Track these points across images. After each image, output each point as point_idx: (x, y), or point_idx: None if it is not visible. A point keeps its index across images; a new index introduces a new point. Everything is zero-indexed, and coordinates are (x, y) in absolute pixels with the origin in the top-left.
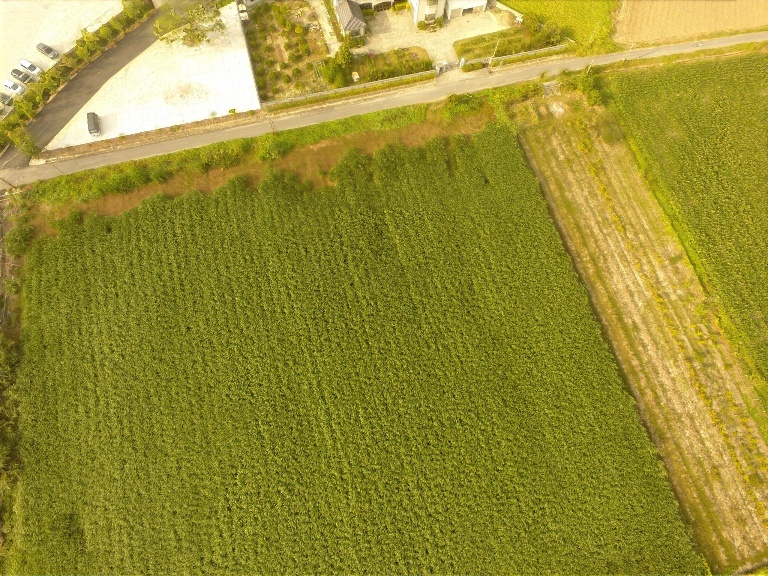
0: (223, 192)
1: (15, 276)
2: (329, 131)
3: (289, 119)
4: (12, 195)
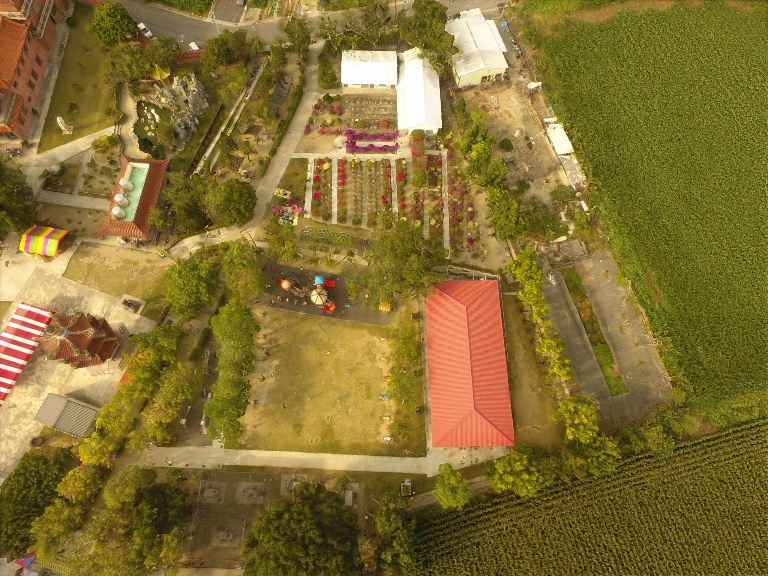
0: (677, 8)
1: (536, 61)
2: None
3: None
4: (510, 7)
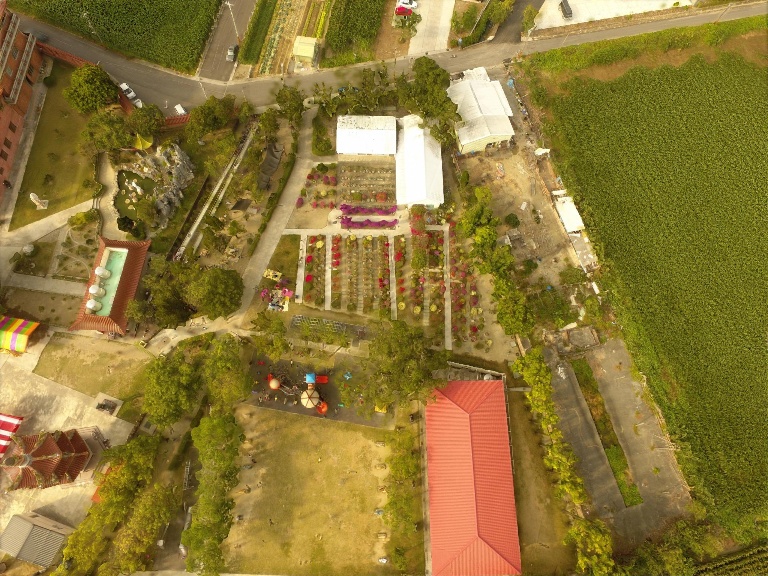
0: (693, 65)
1: None
2: (757, 23)
3: (718, 14)
4: (517, 63)
